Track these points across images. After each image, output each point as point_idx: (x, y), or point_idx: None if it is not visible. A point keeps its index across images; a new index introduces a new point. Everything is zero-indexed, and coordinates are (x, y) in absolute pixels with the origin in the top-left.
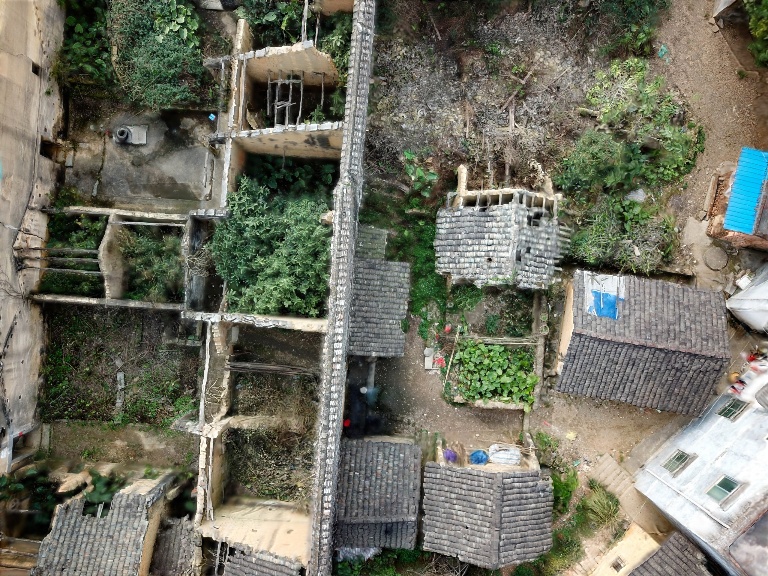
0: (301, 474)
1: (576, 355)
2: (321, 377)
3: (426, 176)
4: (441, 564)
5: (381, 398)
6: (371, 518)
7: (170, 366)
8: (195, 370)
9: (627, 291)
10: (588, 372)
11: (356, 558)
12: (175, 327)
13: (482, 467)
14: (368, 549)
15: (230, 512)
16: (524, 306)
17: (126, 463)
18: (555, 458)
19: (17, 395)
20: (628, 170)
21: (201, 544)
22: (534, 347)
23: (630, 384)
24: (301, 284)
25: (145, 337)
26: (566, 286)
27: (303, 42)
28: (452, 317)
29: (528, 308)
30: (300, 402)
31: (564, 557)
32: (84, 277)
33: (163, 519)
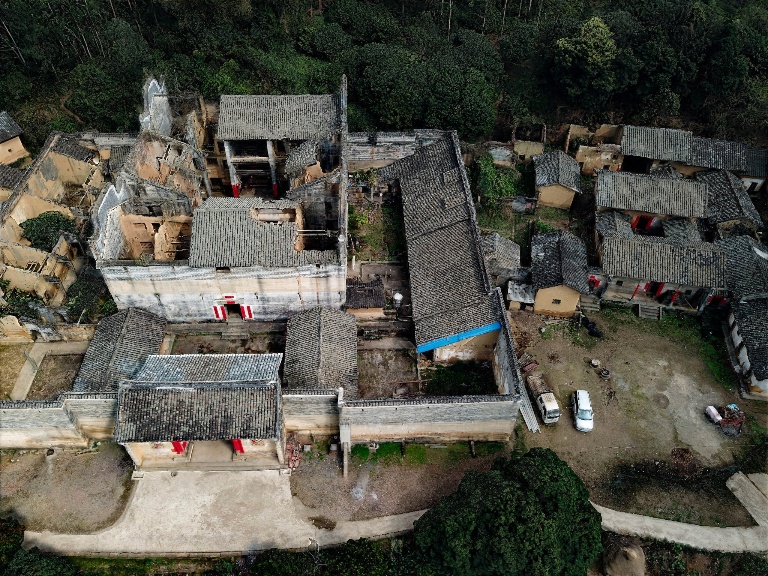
0: None
1: None
2: None
3: None
4: None
5: None
6: None
7: None
8: None
9: None
10: None
11: None
12: None
13: (4, 199)
14: None
15: None
16: None
17: None
18: None
19: None
20: None
21: (98, 165)
22: None
23: None
24: None
25: None
26: None
27: (5, 266)
28: None
29: None
30: None
31: None
32: None
33: None
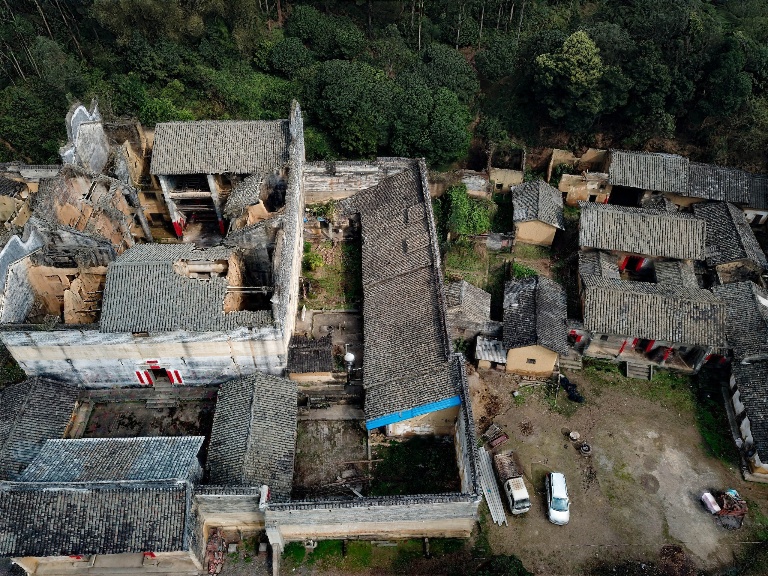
0: None
1: None
2: None
3: None
4: None
5: None
6: None
7: None
8: None
9: None
10: None
11: None
12: None
13: None
14: None
15: None
16: None
17: None
18: None
19: None
20: None
21: None
22: None
23: None
24: None
25: None
26: None
27: None
28: None
29: None
30: None
31: None
32: None
33: None
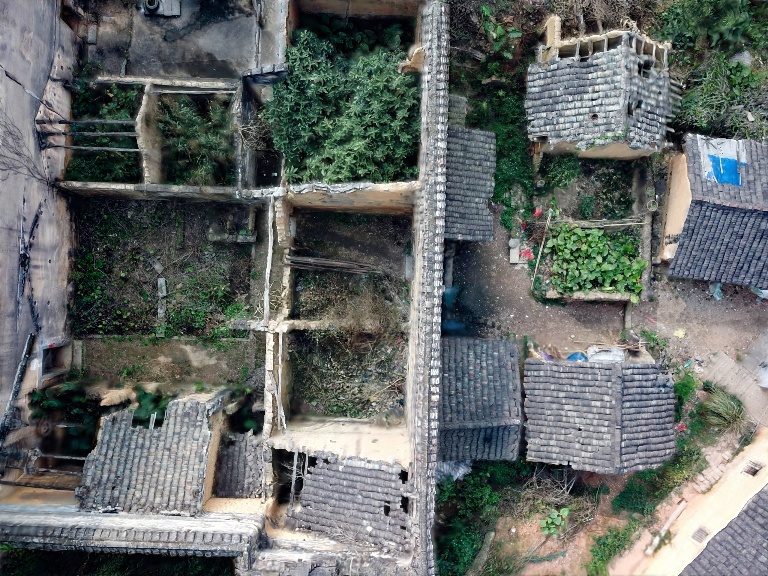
0: (374, 387)
1: (695, 228)
2: (393, 275)
3: (509, 34)
4: (543, 479)
5: (461, 298)
6: (468, 422)
7: (218, 270)
8: (247, 272)
9: (749, 155)
10: (708, 249)
11: (443, 478)
12: (223, 223)
13: None
14: (456, 467)
15: (299, 427)
16: (622, 185)
17: (172, 382)
18: (664, 357)
19: (45, 299)
20: (737, 23)
21: (271, 459)
22: (640, 227)
23: (756, 262)
24: (378, 150)
25: (187, 238)
26: (669, 161)
27: None
28: (540, 201)
29: (627, 187)
30: (373, 300)
31: (681, 467)
32: (118, 160)
33: (223, 435)
